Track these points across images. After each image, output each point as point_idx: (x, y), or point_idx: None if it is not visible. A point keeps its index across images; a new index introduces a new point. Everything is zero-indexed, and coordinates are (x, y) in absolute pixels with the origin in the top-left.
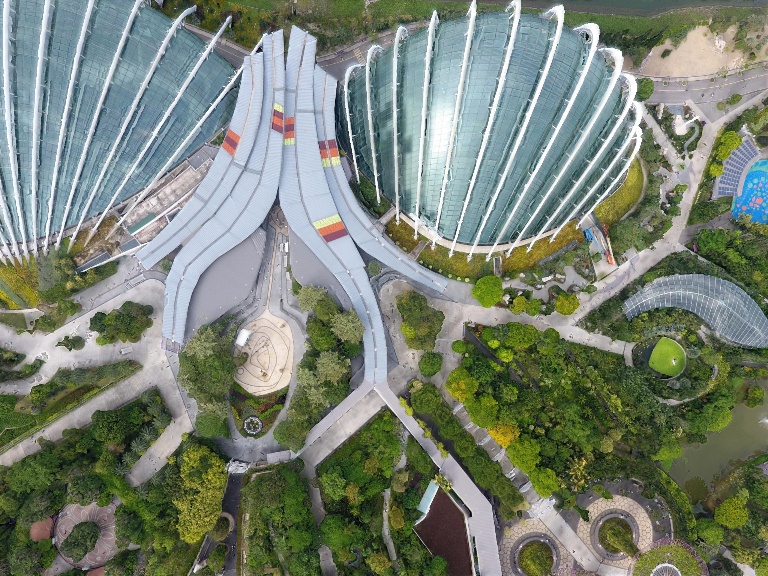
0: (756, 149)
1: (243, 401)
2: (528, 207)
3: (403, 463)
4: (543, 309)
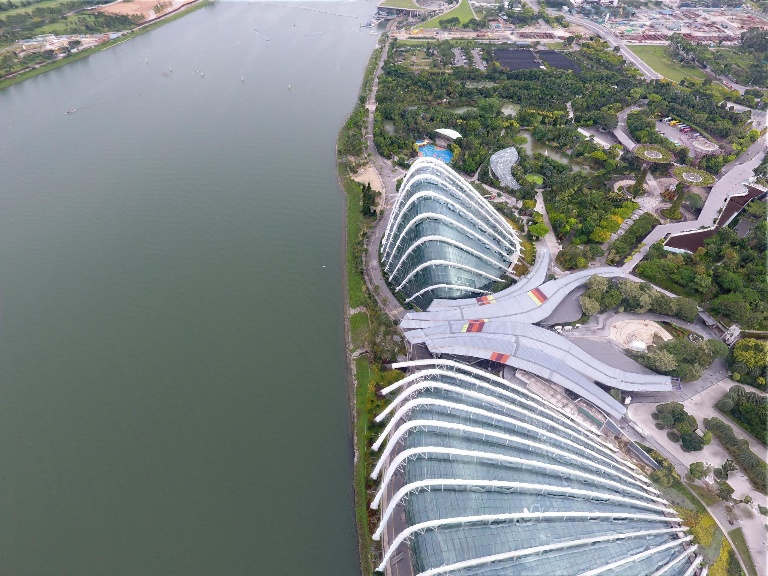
0: None
1: None
2: None
3: None
4: None
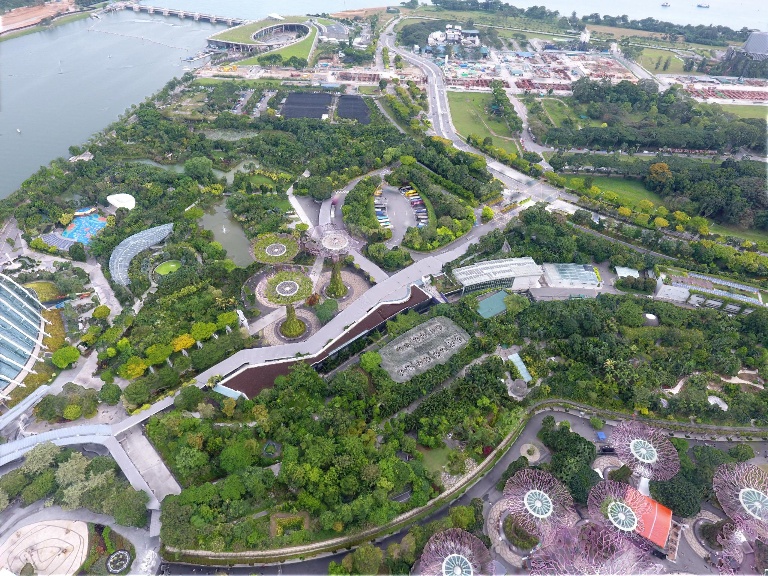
0: (51, 234)
1: (85, 575)
2: (4, 329)
3: (198, 415)
4: (101, 327)
